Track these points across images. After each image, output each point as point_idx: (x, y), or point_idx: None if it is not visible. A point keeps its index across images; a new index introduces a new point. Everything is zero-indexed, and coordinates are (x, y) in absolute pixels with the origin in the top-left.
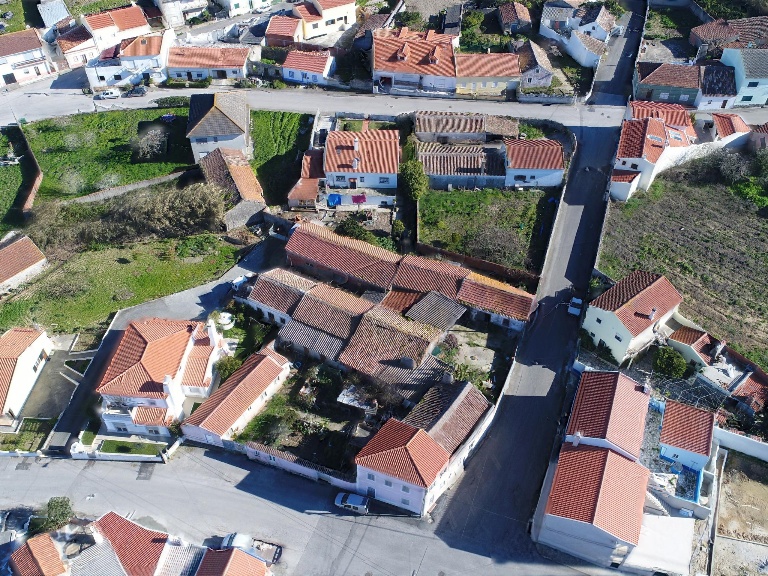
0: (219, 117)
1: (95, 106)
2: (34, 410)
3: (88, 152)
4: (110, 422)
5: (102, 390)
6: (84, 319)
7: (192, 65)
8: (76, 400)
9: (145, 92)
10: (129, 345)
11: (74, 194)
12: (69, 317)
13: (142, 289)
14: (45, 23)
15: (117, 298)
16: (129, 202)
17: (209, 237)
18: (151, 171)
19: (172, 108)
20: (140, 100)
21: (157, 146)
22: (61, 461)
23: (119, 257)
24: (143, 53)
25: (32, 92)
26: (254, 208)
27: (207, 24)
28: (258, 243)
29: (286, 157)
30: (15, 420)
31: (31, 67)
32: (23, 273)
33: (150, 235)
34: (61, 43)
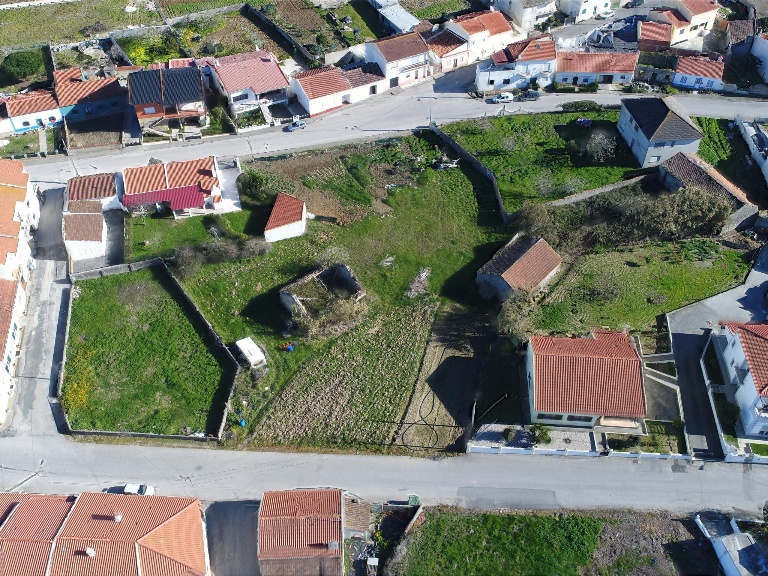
0: (677, 121)
1: (504, 110)
2: (648, 412)
3: (523, 155)
4: (761, 425)
5: (765, 393)
6: (633, 322)
7: (582, 70)
8: (687, 403)
9: (539, 96)
10: (759, 348)
11: (538, 197)
12: (616, 320)
13: (671, 292)
14: (400, 27)
15: (654, 301)
16: (632, 205)
17: (707, 241)
18: (602, 175)
19: (577, 112)
20: (536, 104)
21: (610, 150)
22: (715, 464)
23: (625, 260)
24: (540, 58)
25: (419, 96)
26: (749, 212)
27: (556, 29)
28: (760, 248)
29: (731, 162)
30: (636, 422)
31: (413, 71)
32: (548, 275)
33: (644, 239)
34: (431, 47)
